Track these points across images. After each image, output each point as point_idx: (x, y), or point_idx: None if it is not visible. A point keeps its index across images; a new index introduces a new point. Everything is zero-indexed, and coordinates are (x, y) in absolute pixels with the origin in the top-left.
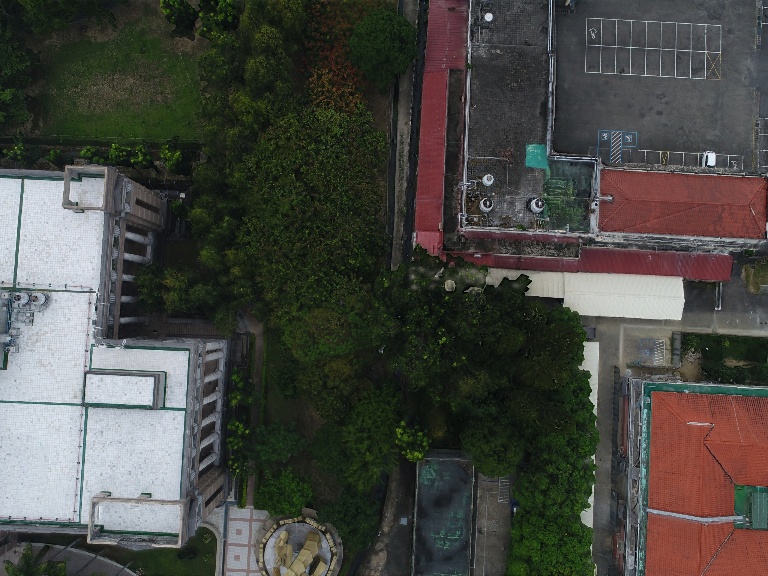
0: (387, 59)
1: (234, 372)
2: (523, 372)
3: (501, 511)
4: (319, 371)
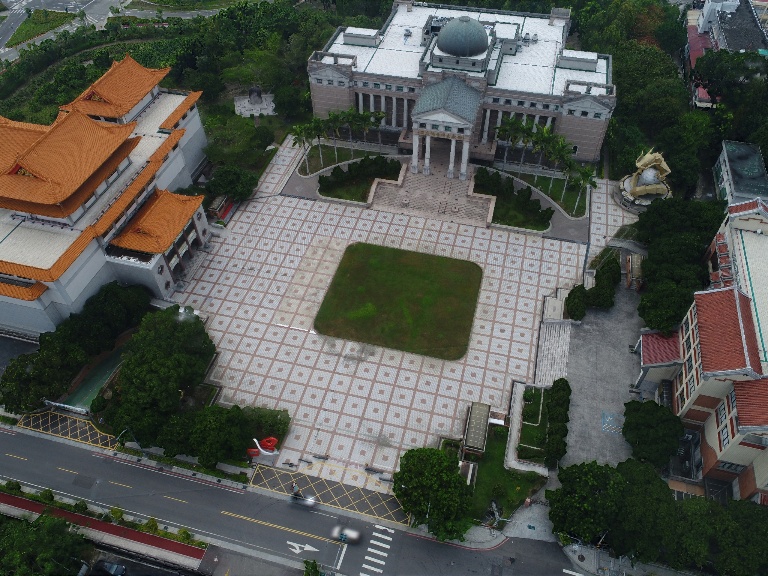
0: (675, 37)
1: None
2: None
3: None
4: None
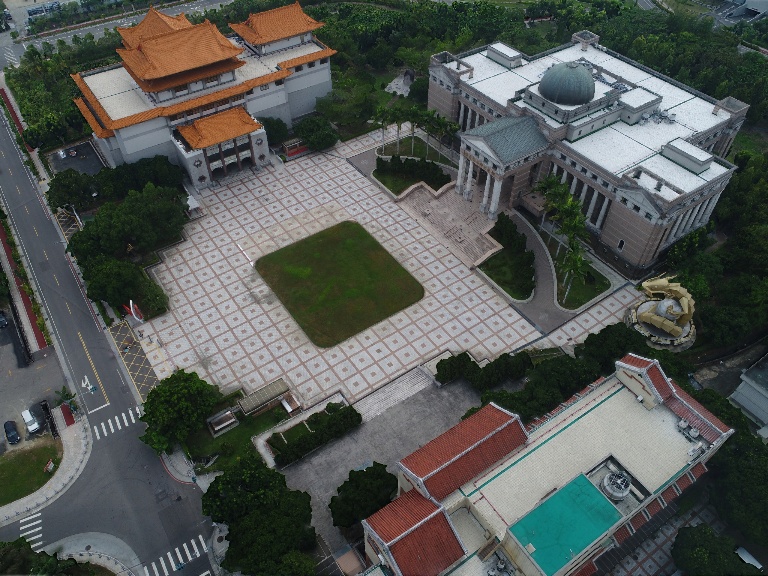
0: None
1: None
2: None
3: None
4: None
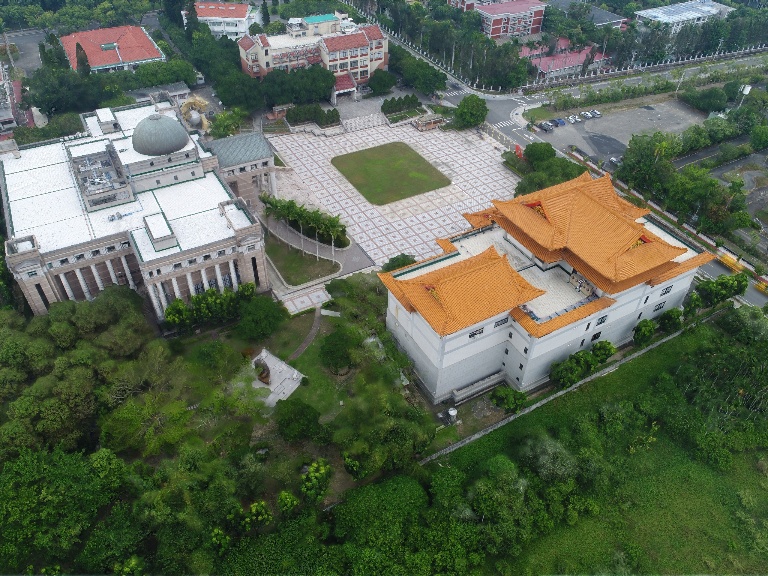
0: None
1: None
2: None
3: None
4: None
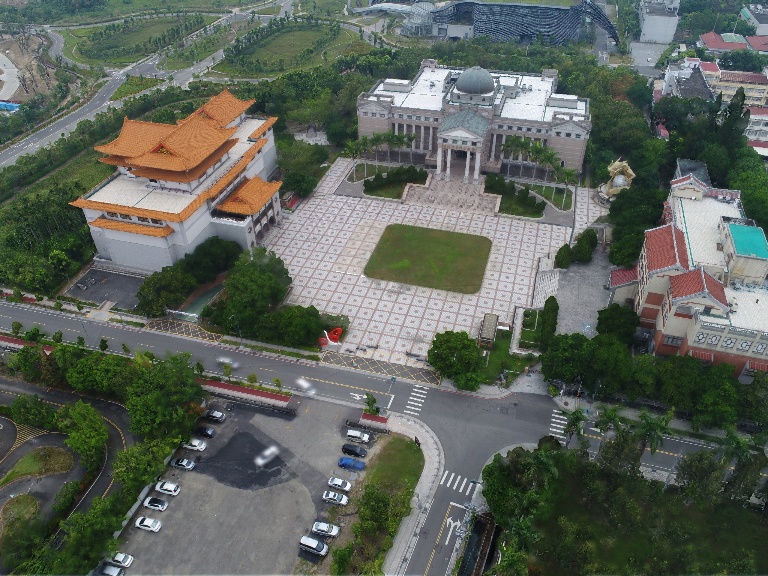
0: (642, 95)
1: None
2: None
3: None
4: None
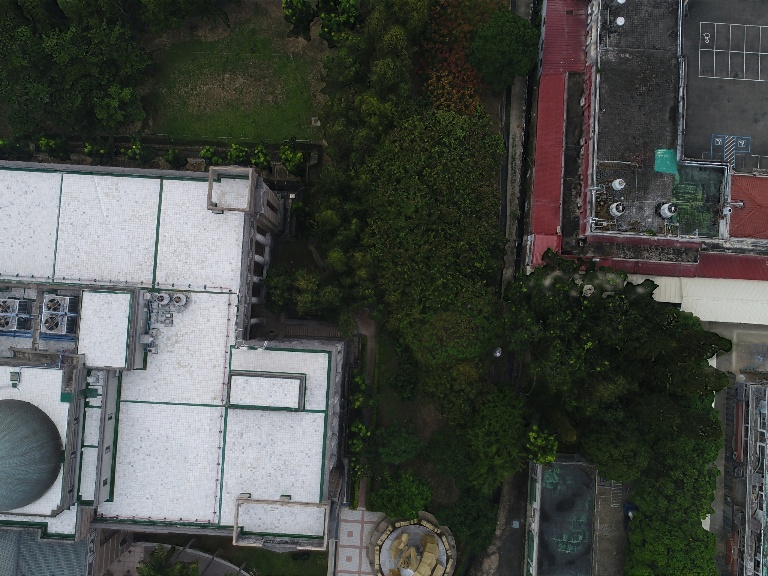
0: (509, 62)
1: (356, 374)
2: (655, 377)
3: (614, 515)
4: (446, 374)
